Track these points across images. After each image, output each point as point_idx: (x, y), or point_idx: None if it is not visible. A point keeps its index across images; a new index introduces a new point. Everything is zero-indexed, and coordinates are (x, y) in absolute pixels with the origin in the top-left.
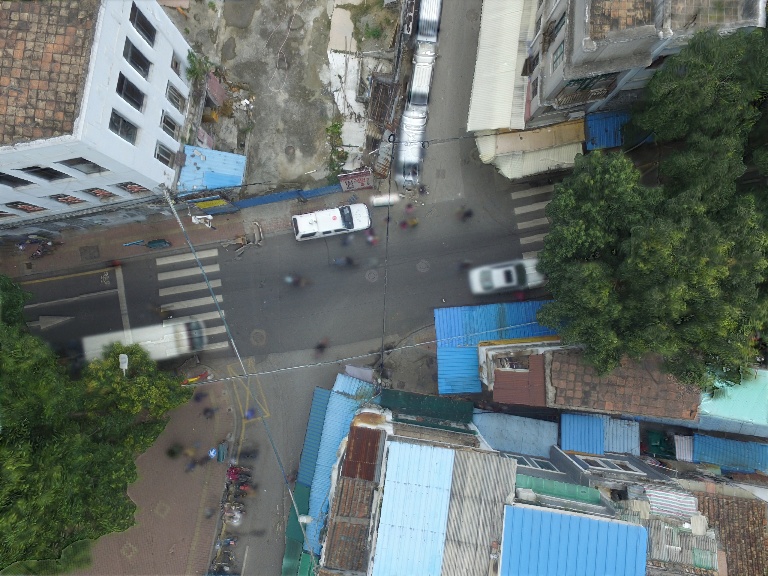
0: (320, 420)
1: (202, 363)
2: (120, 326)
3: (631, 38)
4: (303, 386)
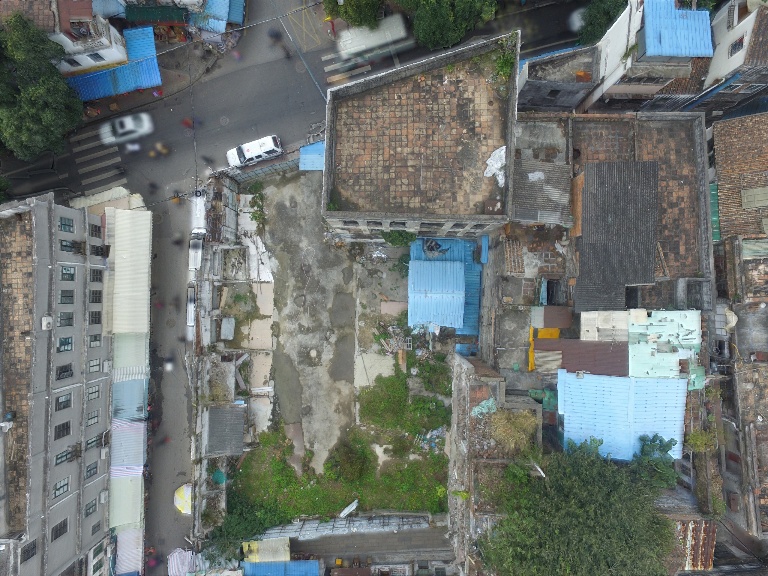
0: (235, 2)
1: (339, 43)
2: (402, 62)
3: (4, 204)
4: (265, 37)
